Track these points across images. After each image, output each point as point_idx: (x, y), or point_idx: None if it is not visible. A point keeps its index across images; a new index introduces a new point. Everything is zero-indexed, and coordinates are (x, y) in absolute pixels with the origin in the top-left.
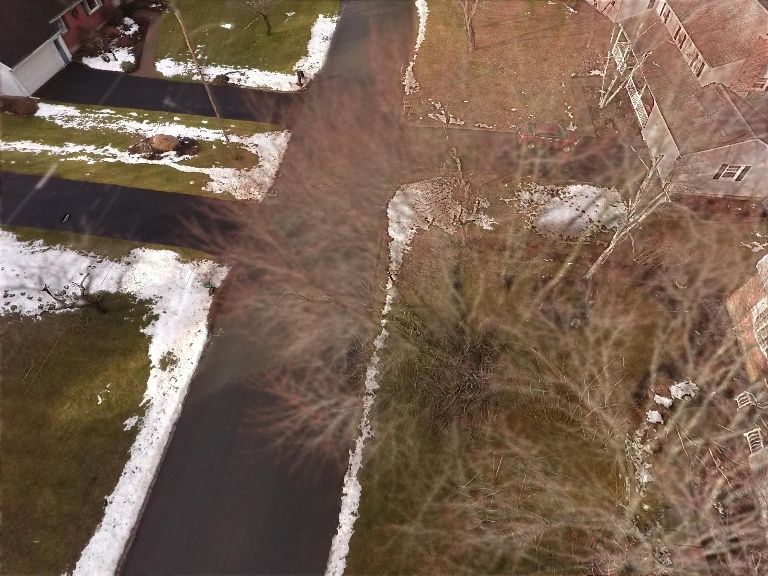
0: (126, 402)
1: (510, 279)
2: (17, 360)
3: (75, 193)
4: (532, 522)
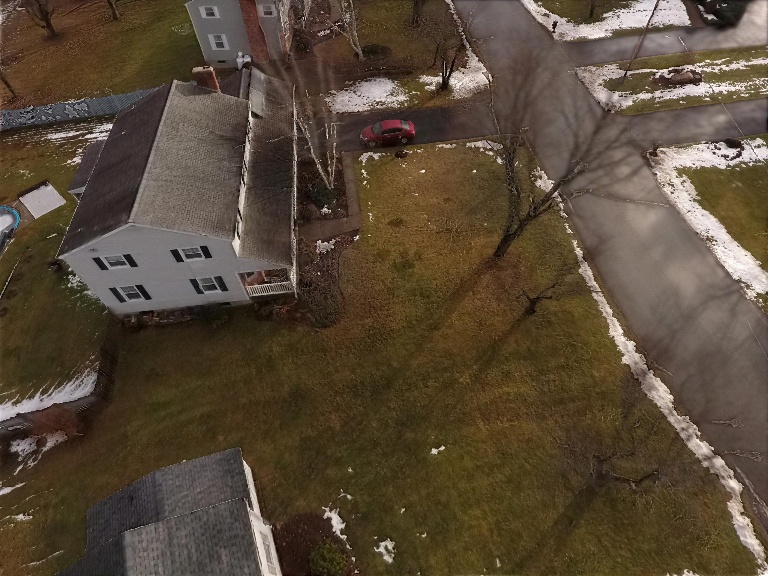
0: (548, 5)
1: (404, 57)
2: (602, 1)
3: (685, 46)
4: (387, 4)
